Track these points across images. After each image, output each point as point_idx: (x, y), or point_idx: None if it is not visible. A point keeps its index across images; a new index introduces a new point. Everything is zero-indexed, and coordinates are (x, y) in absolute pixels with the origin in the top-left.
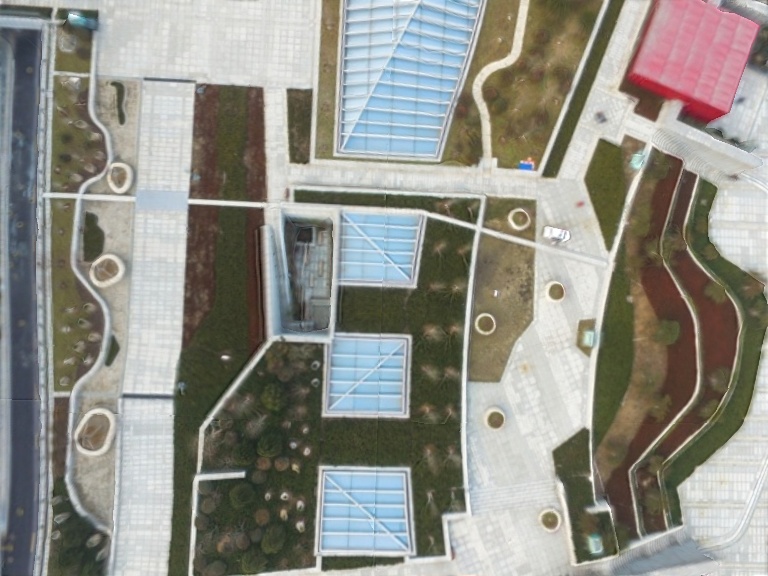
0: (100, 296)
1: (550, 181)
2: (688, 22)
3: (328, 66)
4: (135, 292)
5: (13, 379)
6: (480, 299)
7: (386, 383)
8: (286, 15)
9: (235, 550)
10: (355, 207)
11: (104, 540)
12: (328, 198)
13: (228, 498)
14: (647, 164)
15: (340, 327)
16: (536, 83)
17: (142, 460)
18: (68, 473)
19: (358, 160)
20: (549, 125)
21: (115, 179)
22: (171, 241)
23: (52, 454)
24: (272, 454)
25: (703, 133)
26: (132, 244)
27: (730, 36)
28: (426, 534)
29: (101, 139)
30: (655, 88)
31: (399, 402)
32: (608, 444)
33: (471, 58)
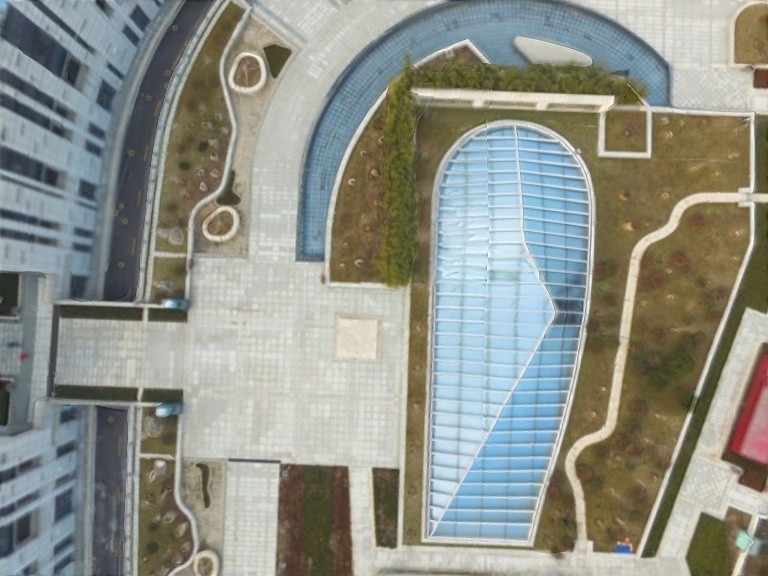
0: None
1: (649, 561)
2: None
3: (415, 446)
4: None
5: None
6: None
7: None
8: (371, 389)
9: None
10: None
11: None
12: None
13: None
14: (754, 540)
15: None
16: (634, 462)
17: None
18: None
19: (447, 546)
20: (648, 504)
21: (202, 571)
22: None
23: None
24: None
25: None
26: None
27: None
28: None
29: (187, 527)
30: (763, 466)
31: None
32: None
33: (563, 432)
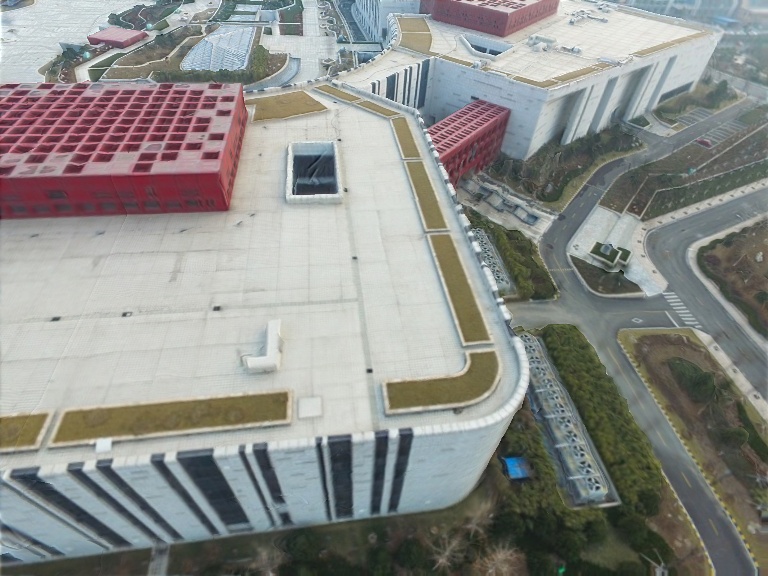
0: None
1: None
2: None
3: None
4: None
5: None
6: None
7: None
8: None
9: None
10: None
11: None
12: None
13: None
14: None
15: None
16: None
17: None
18: None
19: None
20: None
21: None
22: None
23: None
24: None
25: None
26: None
27: None
28: None
29: None
30: None
31: None
32: (177, 4)
33: None
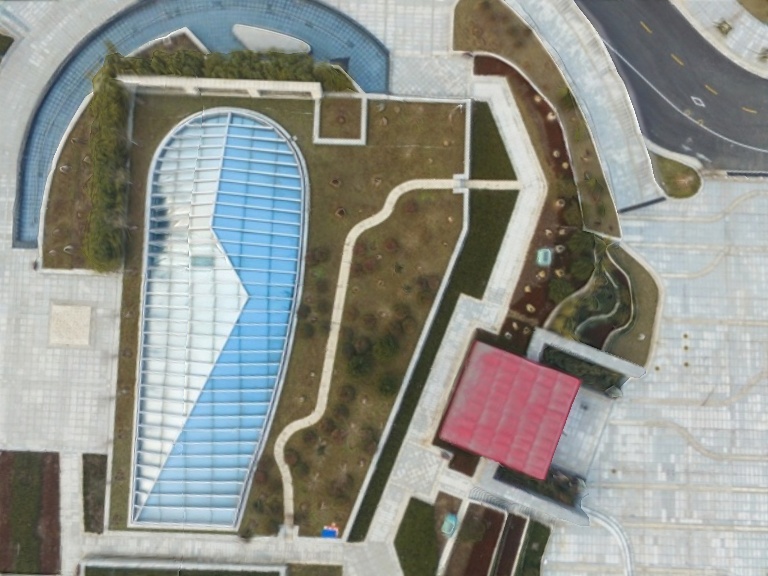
0: None
1: (357, 545)
2: (500, 381)
3: (123, 431)
4: None
5: None
6: None
7: None
8: (83, 375)
9: None
10: None
11: None
12: (119, 575)
13: None
14: (462, 524)
15: None
16: (338, 447)
17: None
18: None
19: (153, 531)
20: (354, 488)
21: None
22: None
23: None
24: None
25: (522, 492)
26: None
27: (547, 395)
28: None
29: None
30: (466, 451)
31: None
32: None
33: (272, 418)
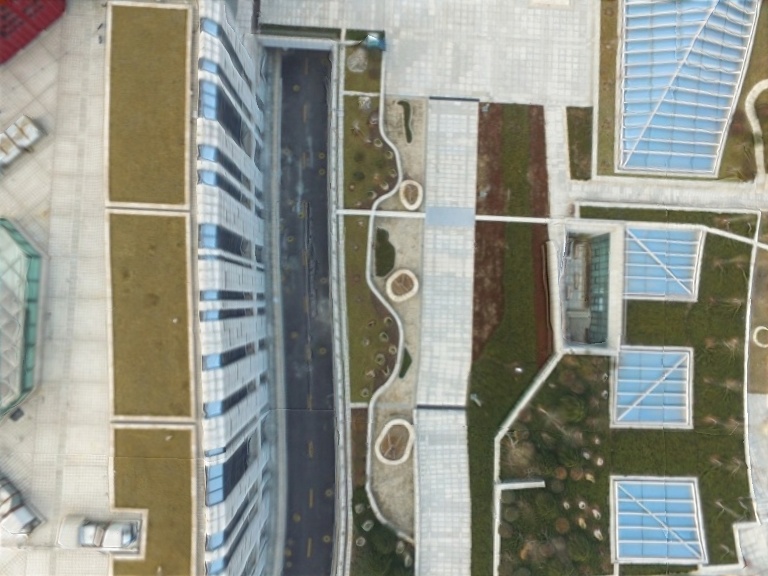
0: (394, 310)
1: None
2: None
3: (608, 84)
4: (426, 306)
5: (287, 389)
6: (757, 312)
7: (670, 395)
8: (564, 34)
9: (539, 557)
10: (638, 223)
11: (406, 547)
12: (612, 214)
13: (535, 507)
14: None
15: (625, 340)
16: None
17: (438, 469)
18: (368, 482)
19: (638, 176)
20: None
21: (408, 196)
22: (459, 256)
23: (350, 463)
24: (574, 464)
25: None
26: (422, 259)
27: None
28: (717, 542)
29: (392, 157)
30: None
31: (683, 413)
32: None
33: (744, 76)
